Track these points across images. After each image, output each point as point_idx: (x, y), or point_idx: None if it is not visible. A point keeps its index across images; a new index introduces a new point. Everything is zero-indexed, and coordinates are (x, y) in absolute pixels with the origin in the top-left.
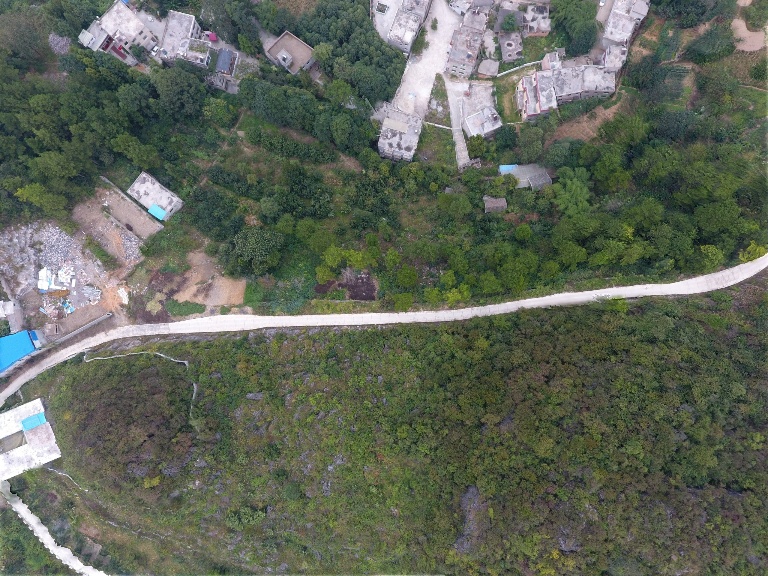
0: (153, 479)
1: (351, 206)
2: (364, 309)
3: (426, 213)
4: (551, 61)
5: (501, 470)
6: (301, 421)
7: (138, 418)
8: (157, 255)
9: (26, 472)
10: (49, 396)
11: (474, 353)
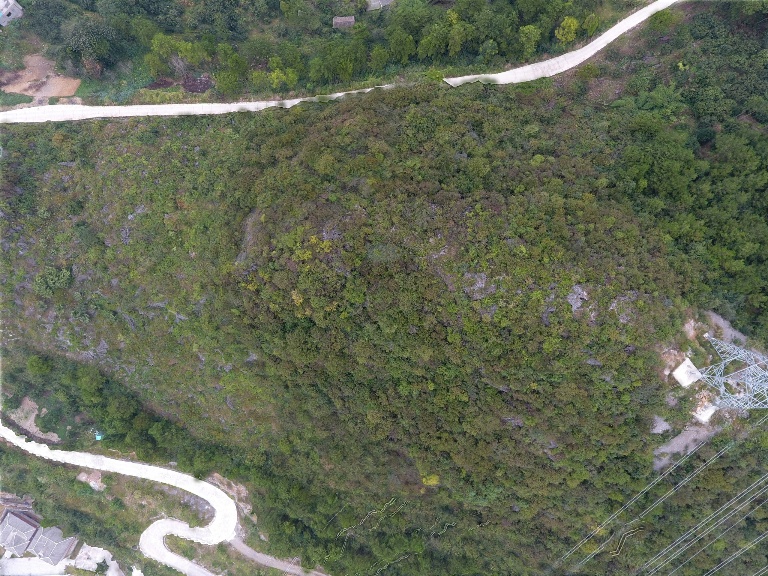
0: None
1: (199, 21)
2: (195, 99)
3: (274, 28)
4: None
5: (281, 187)
6: (105, 175)
7: None
8: None
9: None
10: None
11: None
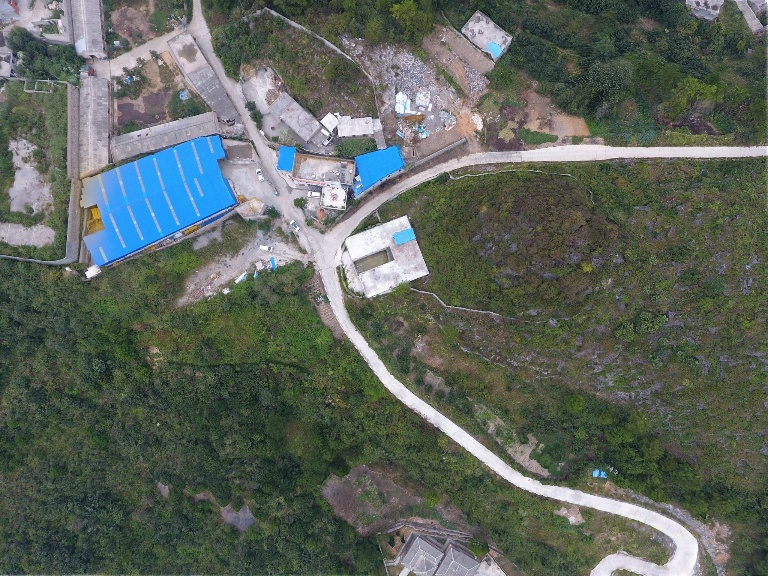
0: (589, 265)
1: (665, 59)
2: (715, 142)
3: (739, 68)
4: None
5: None
6: (710, 224)
7: (570, 205)
8: (499, 89)
9: (371, 299)
10: (409, 217)
11: None
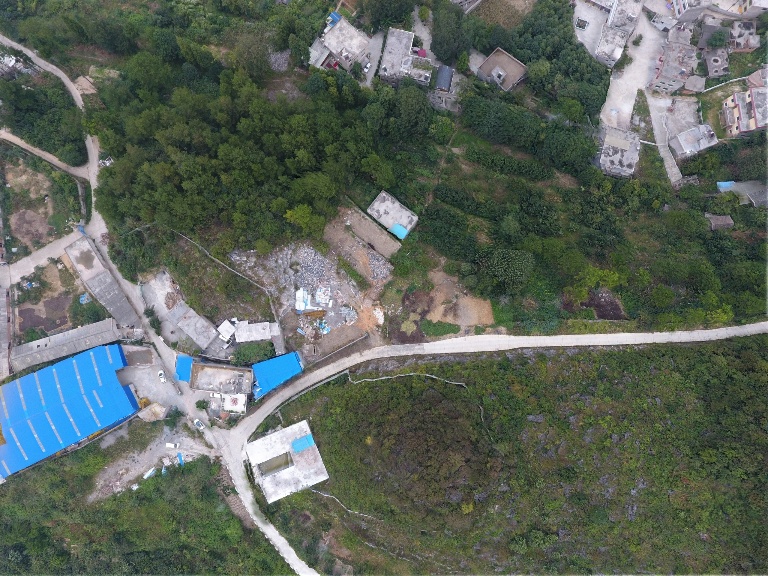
0: (469, 504)
1: (578, 224)
2: (618, 329)
3: (653, 231)
4: (763, 77)
5: None
6: (597, 444)
7: (451, 443)
8: (404, 275)
9: None
10: (310, 417)
11: (759, 375)
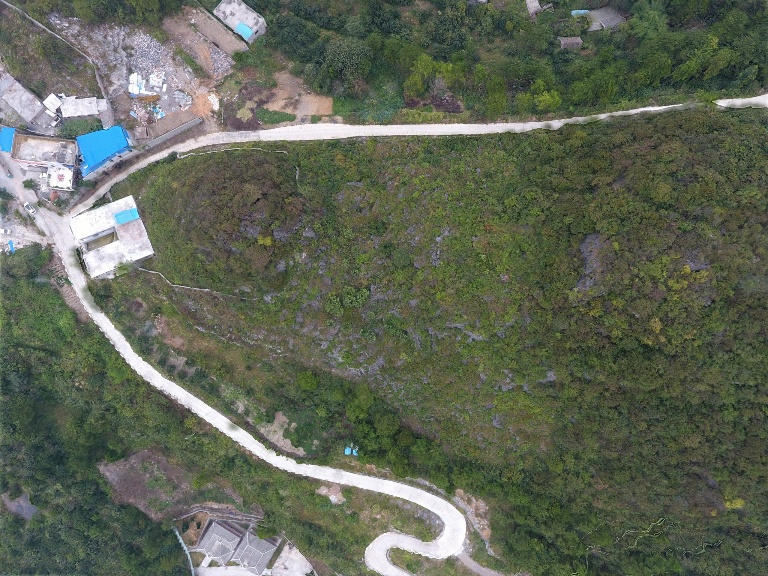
0: (266, 238)
1: (430, 40)
2: (453, 120)
3: (504, 48)
4: None
5: (620, 214)
6: (407, 197)
7: (250, 179)
8: (245, 70)
9: (111, 281)
10: (139, 197)
11: (573, 141)
